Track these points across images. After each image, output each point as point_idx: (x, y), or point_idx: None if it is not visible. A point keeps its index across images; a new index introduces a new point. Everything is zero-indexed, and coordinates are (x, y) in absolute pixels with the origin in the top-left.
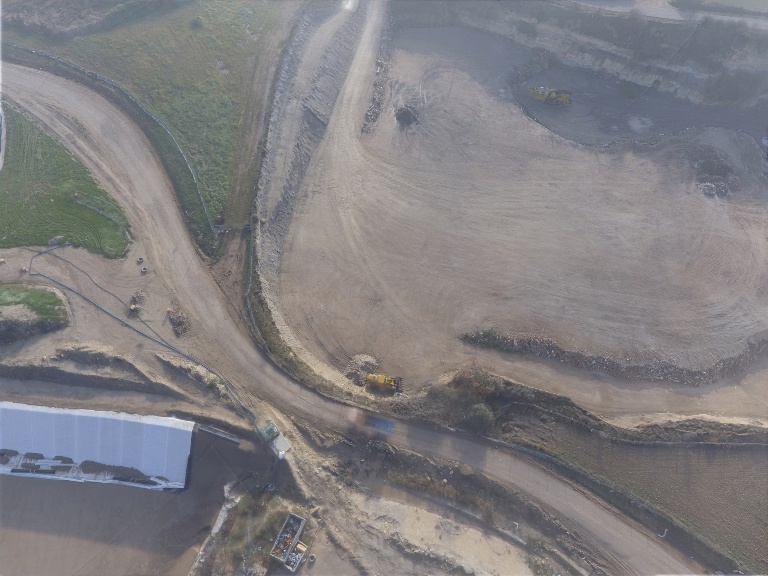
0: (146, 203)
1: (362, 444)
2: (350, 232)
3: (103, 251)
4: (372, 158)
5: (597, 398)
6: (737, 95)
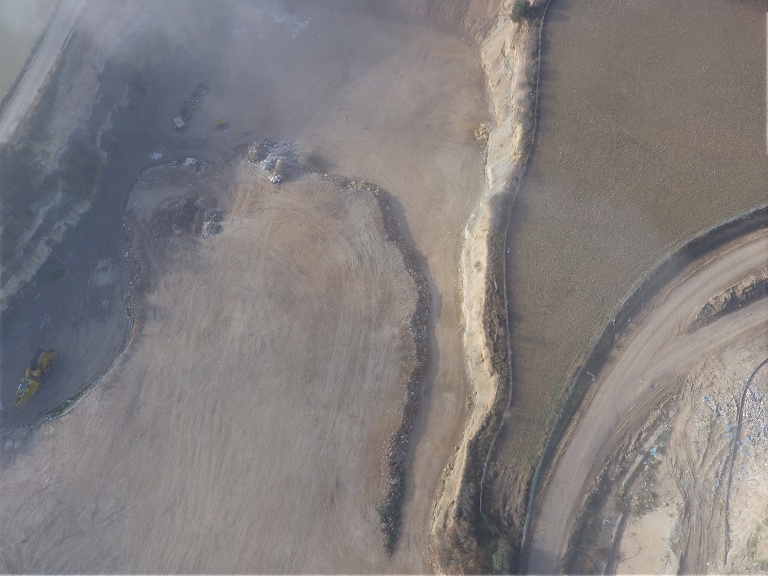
0: None
1: None
2: None
3: None
4: None
5: (450, 397)
6: (91, 167)
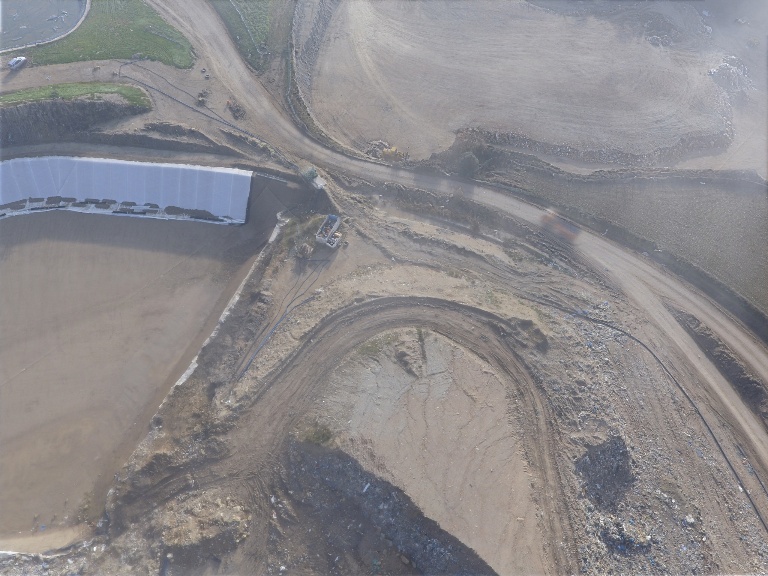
0: (205, 35)
1: (380, 185)
2: (365, 64)
3: (174, 63)
4: (382, 16)
5: None
6: None
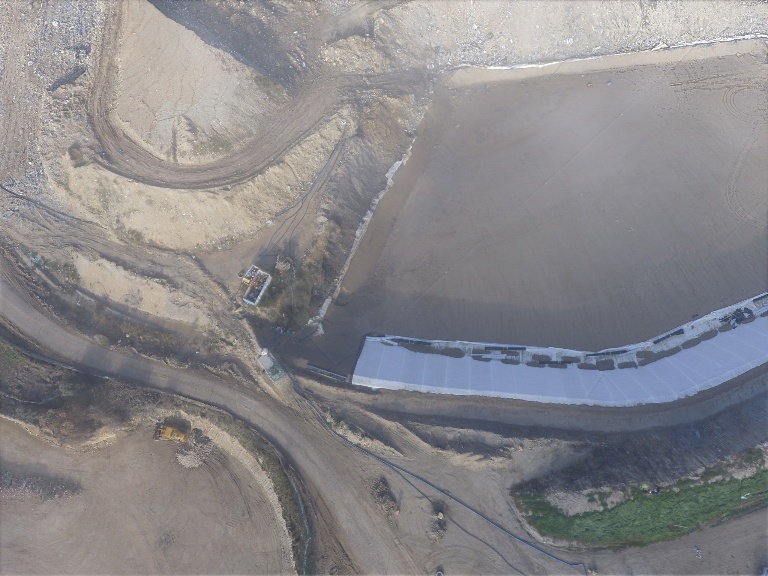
0: None
1: (195, 366)
2: None
3: None
4: None
5: None
6: None
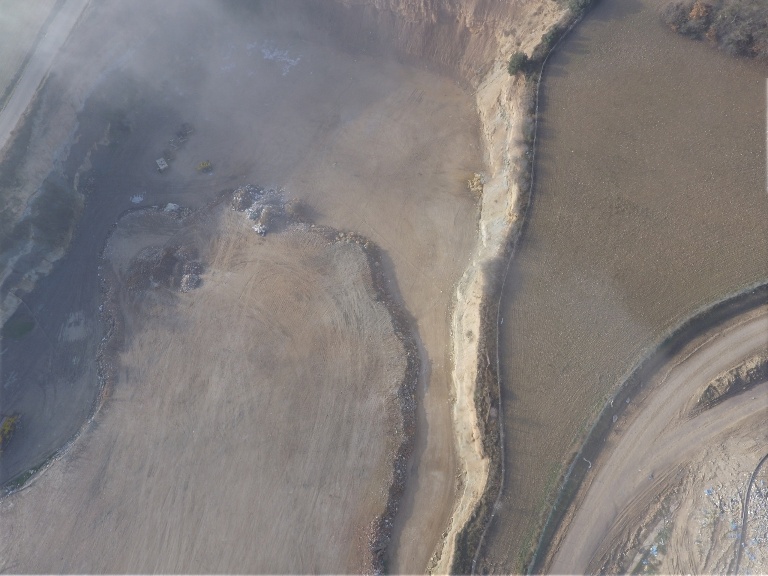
0: None
1: None
2: None
3: None
4: None
5: (439, 475)
6: (66, 212)
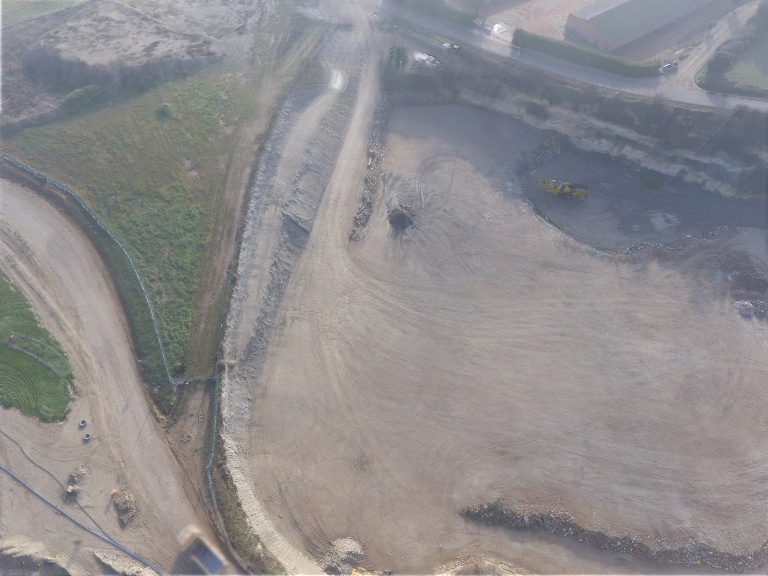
0: (94, 345)
1: None
2: (334, 371)
3: (39, 413)
4: (361, 273)
5: None
6: None
